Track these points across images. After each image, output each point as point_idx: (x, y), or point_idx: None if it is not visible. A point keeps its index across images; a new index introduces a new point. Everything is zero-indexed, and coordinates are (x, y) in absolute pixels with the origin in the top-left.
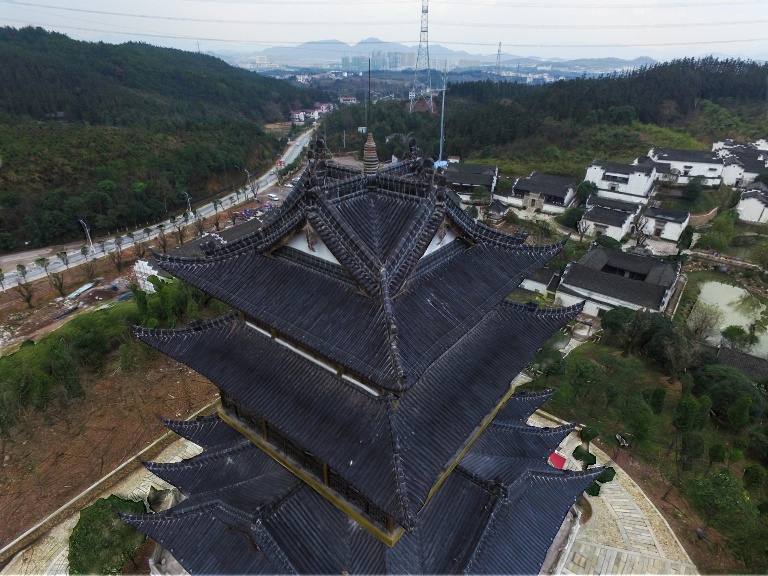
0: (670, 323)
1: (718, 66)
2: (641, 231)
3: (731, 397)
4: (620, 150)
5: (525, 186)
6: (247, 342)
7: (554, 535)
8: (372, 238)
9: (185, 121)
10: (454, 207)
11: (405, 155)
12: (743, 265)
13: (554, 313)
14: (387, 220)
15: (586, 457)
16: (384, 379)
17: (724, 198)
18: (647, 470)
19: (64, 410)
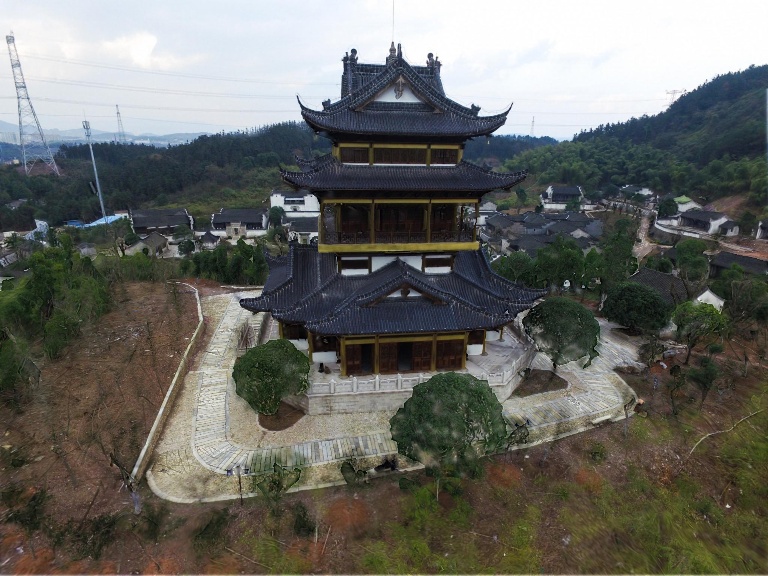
0: None
1: None
2: None
3: None
4: (281, 185)
5: (223, 219)
6: (354, 172)
7: None
8: None
9: None
10: None
11: (52, 218)
12: None
13: None
14: None
15: None
16: (487, 126)
17: None
18: None
19: (17, 402)
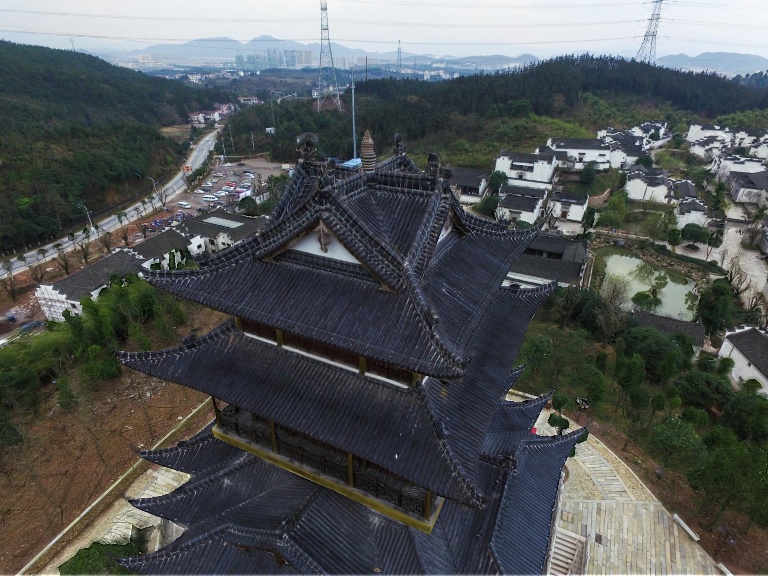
0: (591, 295)
1: (594, 62)
2: (551, 214)
3: (657, 353)
4: (522, 141)
5: None
6: (250, 353)
7: (554, 496)
8: (382, 234)
9: (69, 127)
10: (452, 199)
11: None
12: (637, 238)
13: (533, 292)
14: (392, 215)
15: (560, 423)
16: (434, 368)
17: (614, 180)
18: (605, 427)
19: None
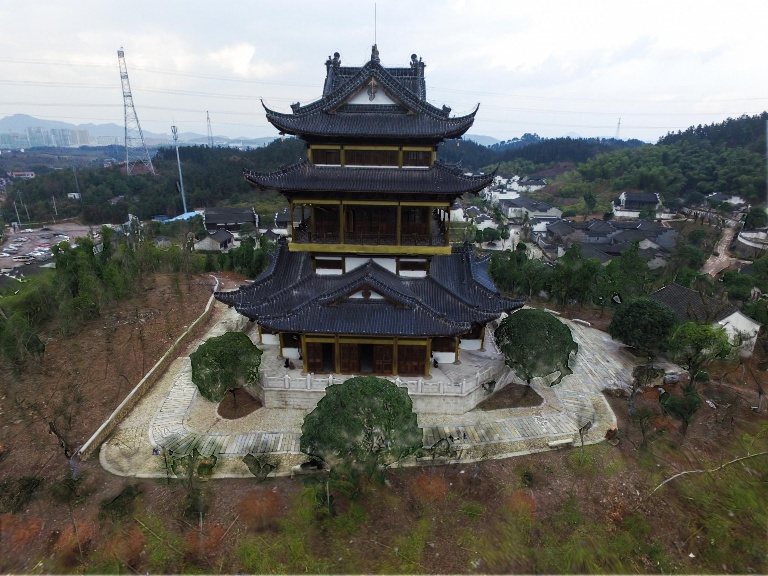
0: None
1: None
2: None
3: None
4: None
5: (285, 218)
6: (324, 173)
7: None
8: None
9: None
10: None
11: (143, 213)
12: None
13: None
14: None
15: None
16: None
17: None
18: None
19: (22, 371)
